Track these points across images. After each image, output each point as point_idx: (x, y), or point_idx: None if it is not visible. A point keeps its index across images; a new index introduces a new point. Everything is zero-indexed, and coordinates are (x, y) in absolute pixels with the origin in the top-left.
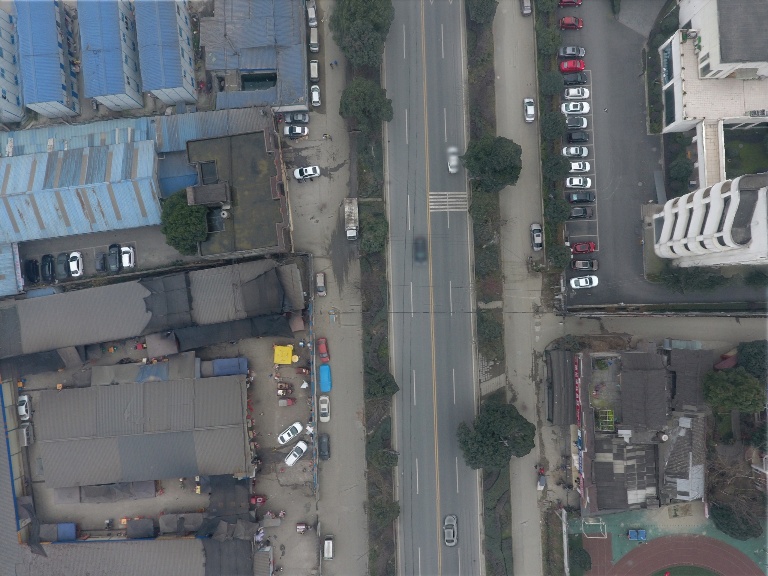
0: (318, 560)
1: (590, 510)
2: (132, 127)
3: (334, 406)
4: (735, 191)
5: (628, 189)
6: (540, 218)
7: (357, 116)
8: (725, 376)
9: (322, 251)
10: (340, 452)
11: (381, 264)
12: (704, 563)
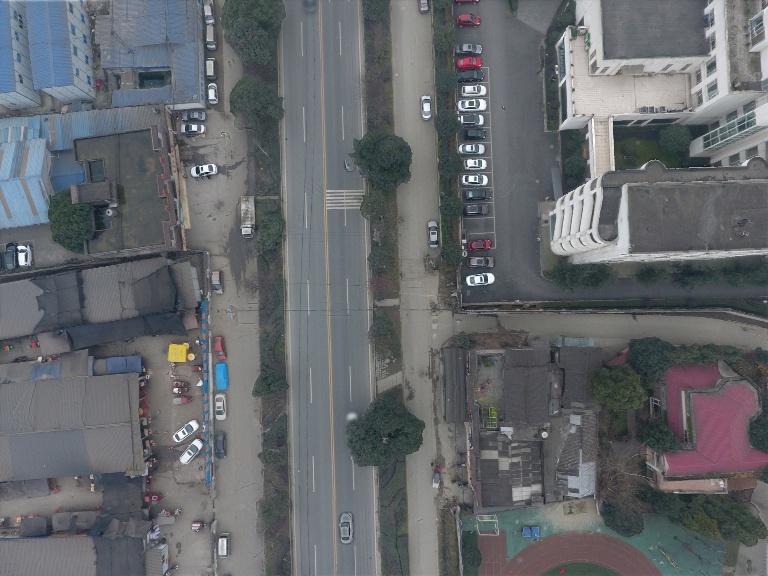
0: (212, 558)
1: (481, 507)
2: (25, 125)
3: (231, 404)
4: (599, 188)
5: (525, 186)
6: (437, 216)
7: (245, 114)
8: (608, 373)
9: (219, 249)
10: (237, 450)
11: (277, 262)
12: (599, 560)
